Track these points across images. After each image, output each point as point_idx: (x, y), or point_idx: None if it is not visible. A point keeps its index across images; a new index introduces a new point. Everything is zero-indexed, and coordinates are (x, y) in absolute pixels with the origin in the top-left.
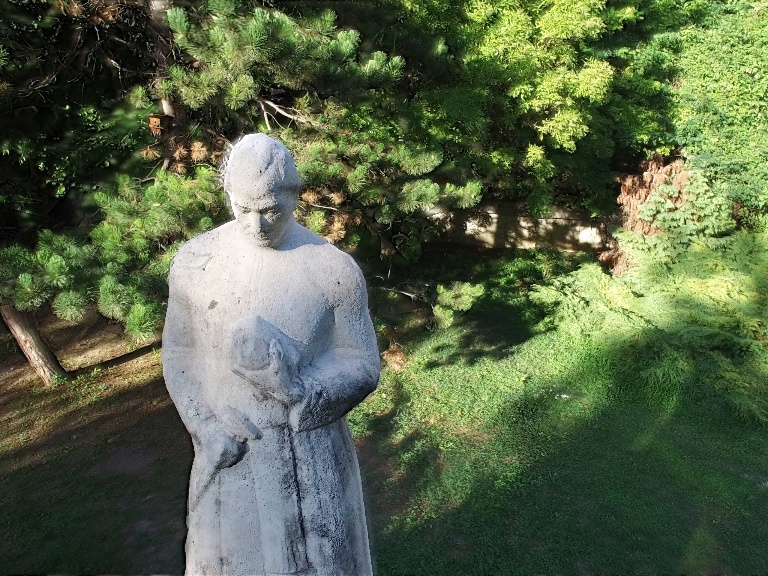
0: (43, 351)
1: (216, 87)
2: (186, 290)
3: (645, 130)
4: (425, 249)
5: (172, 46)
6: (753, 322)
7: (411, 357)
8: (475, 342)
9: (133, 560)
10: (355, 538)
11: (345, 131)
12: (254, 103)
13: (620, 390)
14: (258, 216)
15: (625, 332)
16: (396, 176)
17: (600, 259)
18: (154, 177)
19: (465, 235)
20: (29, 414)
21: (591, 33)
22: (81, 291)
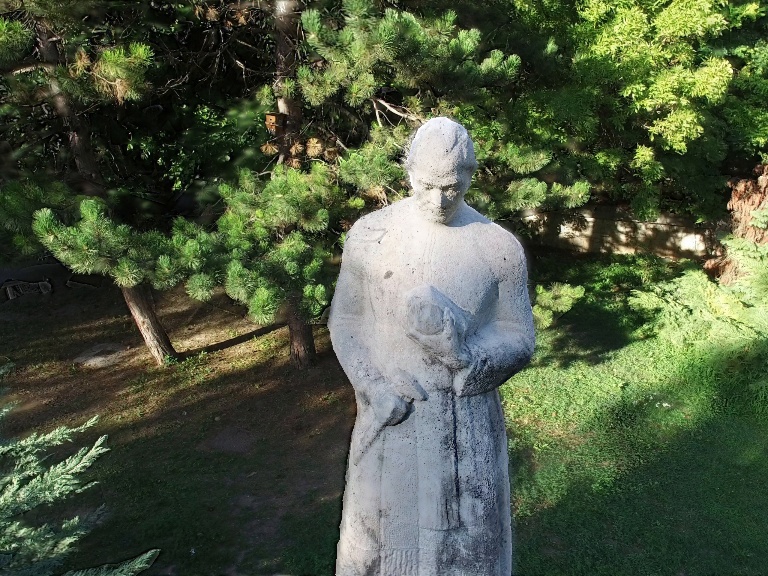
0: (158, 332)
1: (338, 85)
2: (362, 261)
3: (761, 132)
4: None
5: (298, 46)
6: None
7: None
8: (570, 346)
9: (241, 530)
10: (504, 503)
11: None
12: (367, 101)
13: (726, 402)
14: (441, 193)
15: (734, 342)
16: (503, 174)
17: (705, 267)
18: (270, 171)
19: (559, 238)
20: (145, 389)
21: (711, 30)
22: (211, 273)
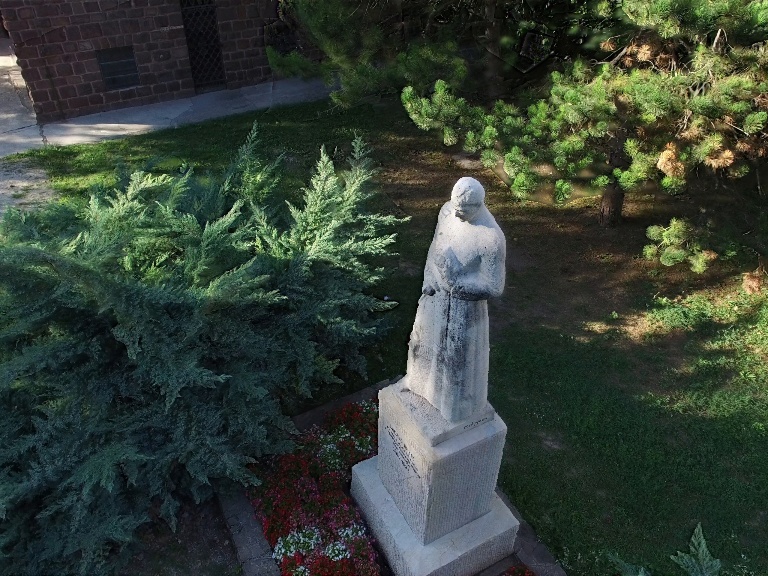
0: None
1: None
2: None
3: None
4: None
5: None
6: None
7: None
8: None
9: None
10: (468, 350)
11: None
12: None
13: None
14: (456, 211)
15: None
16: None
17: None
18: (608, 62)
19: None
20: None
21: None
22: (500, 150)
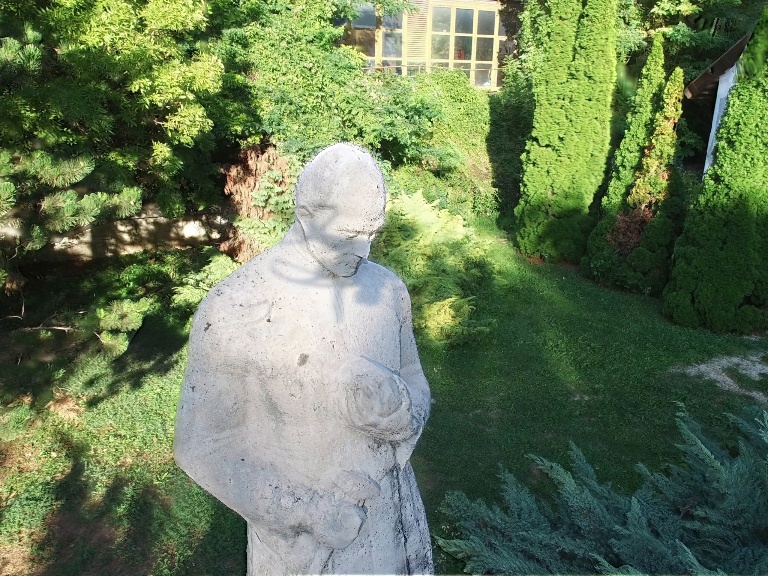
0: None
1: None
2: (247, 354)
3: (236, 121)
4: None
5: None
6: None
7: None
8: (130, 363)
9: None
10: None
11: None
12: None
13: None
14: (367, 241)
15: None
16: (32, 191)
17: (222, 250)
18: None
19: (54, 251)
20: None
21: (199, 26)
22: None
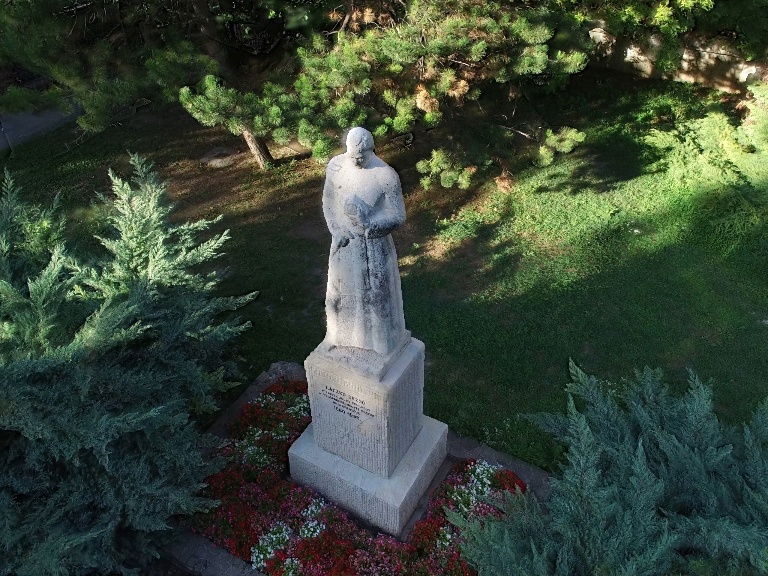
0: (260, 144)
1: None
2: (332, 179)
3: None
4: (580, 74)
5: None
6: None
7: (527, 181)
8: (587, 174)
9: (312, 289)
10: (390, 282)
11: (482, 2)
12: None
13: (691, 233)
14: (356, 160)
15: (710, 185)
16: (518, 42)
17: (736, 108)
18: (338, 31)
19: (624, 62)
20: (251, 188)
21: None
22: (289, 127)
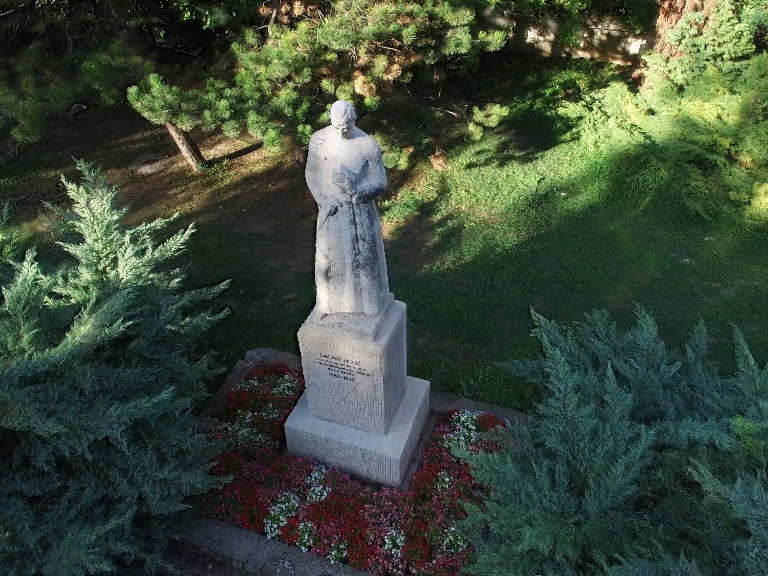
0: (191, 145)
1: None
2: (316, 152)
3: None
4: (487, 57)
5: None
6: (727, 142)
7: (456, 159)
8: (510, 148)
9: (270, 279)
10: (377, 245)
11: None
12: None
13: (610, 191)
14: (341, 131)
15: (622, 146)
16: (442, 25)
17: (633, 76)
18: (267, 25)
19: (525, 43)
20: (188, 190)
21: None
22: (237, 119)
